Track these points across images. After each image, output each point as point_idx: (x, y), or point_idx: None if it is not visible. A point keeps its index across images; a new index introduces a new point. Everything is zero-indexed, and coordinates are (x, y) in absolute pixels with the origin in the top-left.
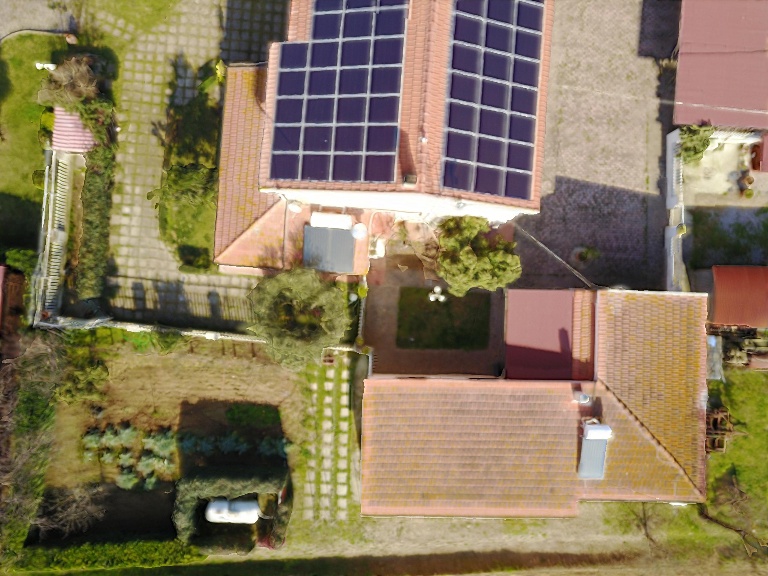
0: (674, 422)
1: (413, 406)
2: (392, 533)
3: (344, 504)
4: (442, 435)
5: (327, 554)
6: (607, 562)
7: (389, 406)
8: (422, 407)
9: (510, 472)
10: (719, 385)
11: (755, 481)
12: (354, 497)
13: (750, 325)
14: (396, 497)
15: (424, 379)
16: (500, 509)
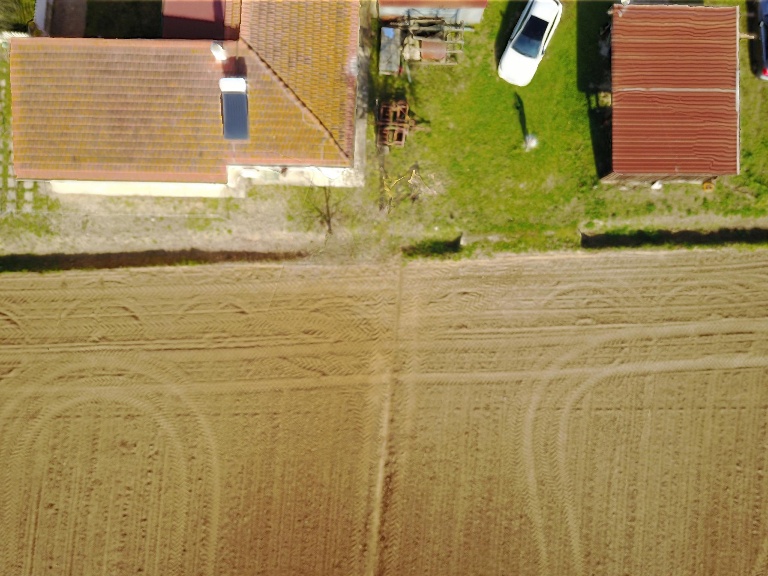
0: (321, 87)
1: (59, 65)
2: (78, 226)
3: (30, 197)
4: (90, 96)
5: (20, 251)
6: (292, 258)
7: (35, 65)
8: (69, 67)
9: (159, 135)
10: (404, 84)
11: (438, 179)
12: (41, 190)
13: (415, 6)
14: (48, 159)
15: (69, 38)
16: (151, 173)
